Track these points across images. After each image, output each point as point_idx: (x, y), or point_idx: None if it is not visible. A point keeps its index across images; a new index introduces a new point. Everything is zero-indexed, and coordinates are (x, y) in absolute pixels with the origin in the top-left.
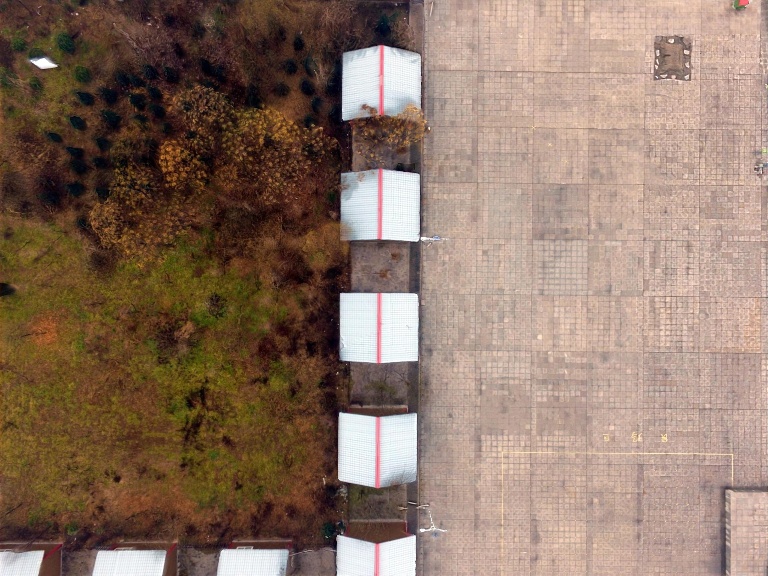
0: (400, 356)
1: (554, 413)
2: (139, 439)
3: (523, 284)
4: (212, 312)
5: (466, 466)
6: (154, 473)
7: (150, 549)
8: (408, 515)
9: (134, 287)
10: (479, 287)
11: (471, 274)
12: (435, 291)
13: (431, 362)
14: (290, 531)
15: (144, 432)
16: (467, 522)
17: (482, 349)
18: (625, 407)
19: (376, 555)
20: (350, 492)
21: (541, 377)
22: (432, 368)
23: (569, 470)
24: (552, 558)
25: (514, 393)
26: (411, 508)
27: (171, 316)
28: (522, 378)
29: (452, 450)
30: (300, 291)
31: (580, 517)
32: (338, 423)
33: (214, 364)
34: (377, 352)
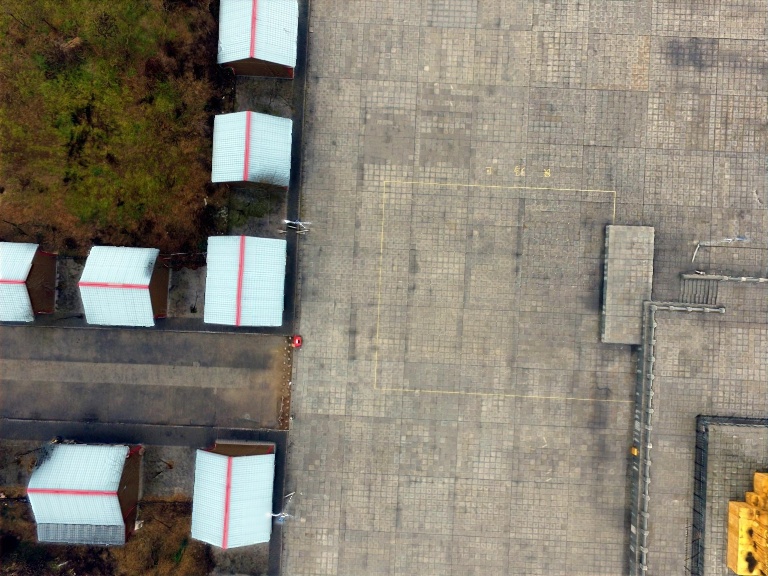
0: (275, 57)
1: (438, 145)
2: (24, 151)
3: (412, 15)
4: (101, 31)
5: (348, 194)
6: (37, 185)
7: (23, 242)
8: (287, 238)
9: (24, 2)
10: (368, 16)
11: (360, 3)
12: (324, 19)
13: (317, 89)
14: (170, 250)
15: (29, 145)
16: (346, 249)
17: (368, 78)
18: (509, 141)
19: (241, 247)
20: (230, 213)
21: (426, 108)
22: (318, 95)
23: (450, 202)
24: (430, 288)
25: (398, 123)
26: (291, 232)
27: (60, 32)
28: (407, 109)
29: (334, 177)
30: (189, 14)
31: (459, 249)
32: (213, 126)
33: (101, 82)
34: (250, 46)
